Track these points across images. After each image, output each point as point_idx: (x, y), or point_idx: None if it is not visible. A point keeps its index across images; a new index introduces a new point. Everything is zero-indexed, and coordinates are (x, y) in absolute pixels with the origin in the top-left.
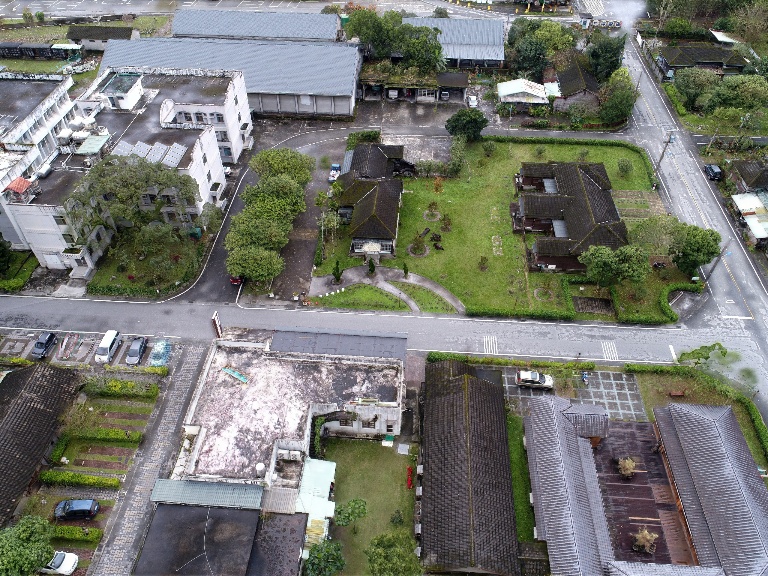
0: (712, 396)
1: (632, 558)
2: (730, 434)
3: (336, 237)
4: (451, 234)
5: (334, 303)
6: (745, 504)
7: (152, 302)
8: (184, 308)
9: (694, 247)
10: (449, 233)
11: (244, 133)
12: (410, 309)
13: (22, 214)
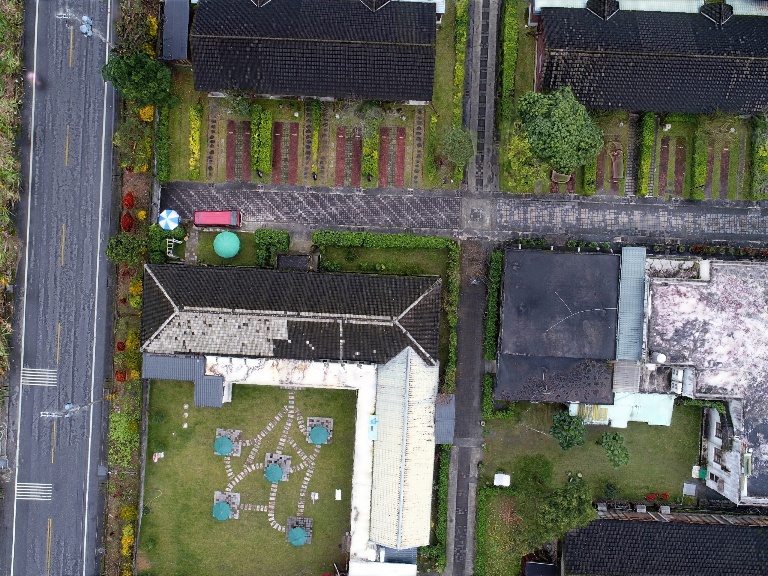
0: None
1: None
2: None
3: None
4: None
5: None
6: None
7: None
8: None
9: None
10: None
11: None
12: None
13: None
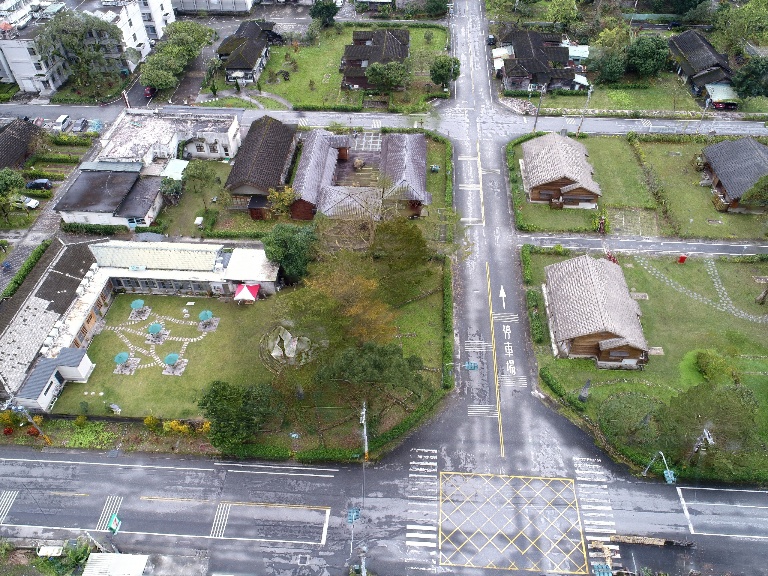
0: (429, 141)
1: None
2: (415, 141)
3: (219, 75)
4: (298, 73)
5: (210, 105)
6: (404, 162)
7: (92, 106)
8: (113, 108)
9: (439, 65)
10: (296, 73)
11: (166, 19)
12: (258, 108)
13: (7, 47)
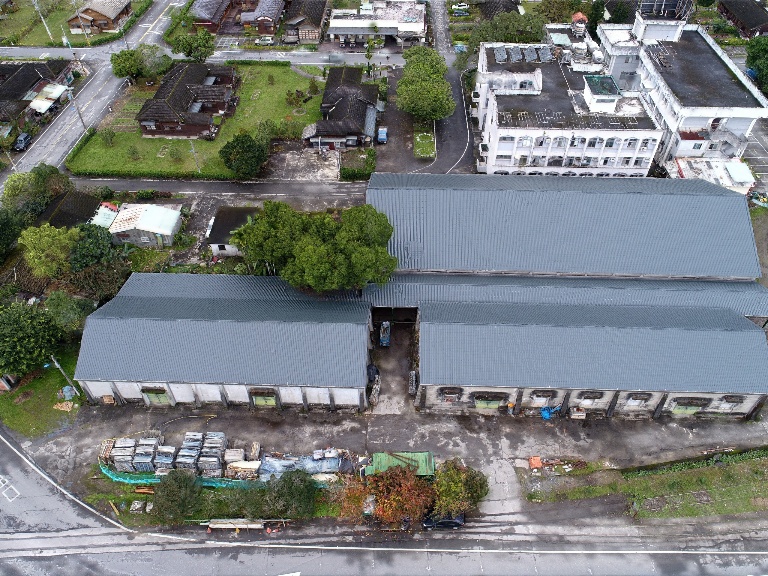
0: None
1: (252, 10)
2: None
3: None
4: None
5: None
6: None
7: None
8: None
9: None
10: None
11: None
12: None
13: None
